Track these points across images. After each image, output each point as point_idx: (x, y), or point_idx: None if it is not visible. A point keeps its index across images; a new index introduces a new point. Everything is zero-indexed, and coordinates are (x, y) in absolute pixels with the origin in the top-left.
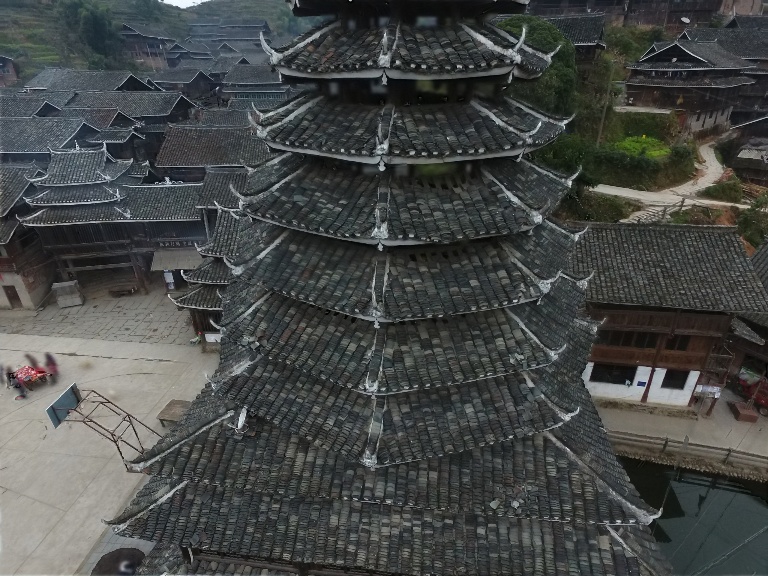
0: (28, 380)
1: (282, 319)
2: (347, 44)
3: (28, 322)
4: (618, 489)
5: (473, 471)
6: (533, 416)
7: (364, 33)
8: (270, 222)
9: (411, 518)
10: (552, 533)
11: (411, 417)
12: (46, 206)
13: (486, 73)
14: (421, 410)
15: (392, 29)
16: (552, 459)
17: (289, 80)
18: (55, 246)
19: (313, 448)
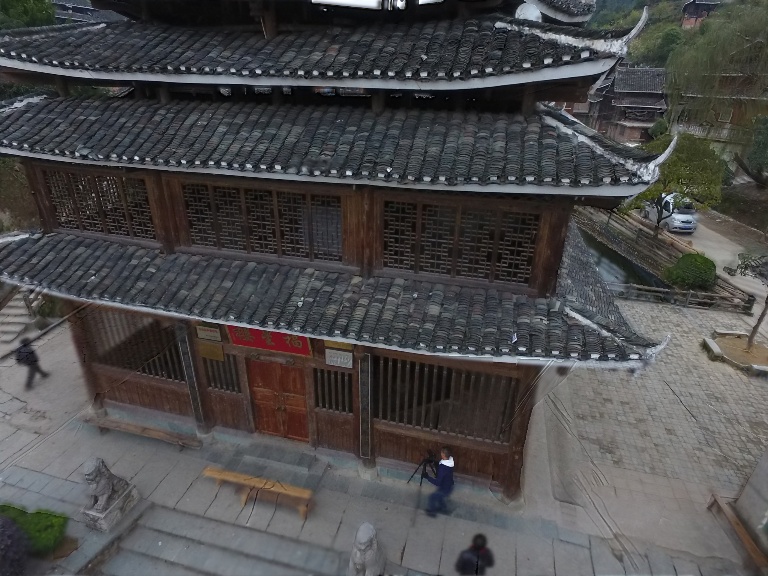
0: None
1: None
2: None
3: None
4: None
5: None
6: None
7: None
8: None
9: None
10: None
11: None
12: None
13: None
14: None
15: None
16: None
17: None
18: None
19: None
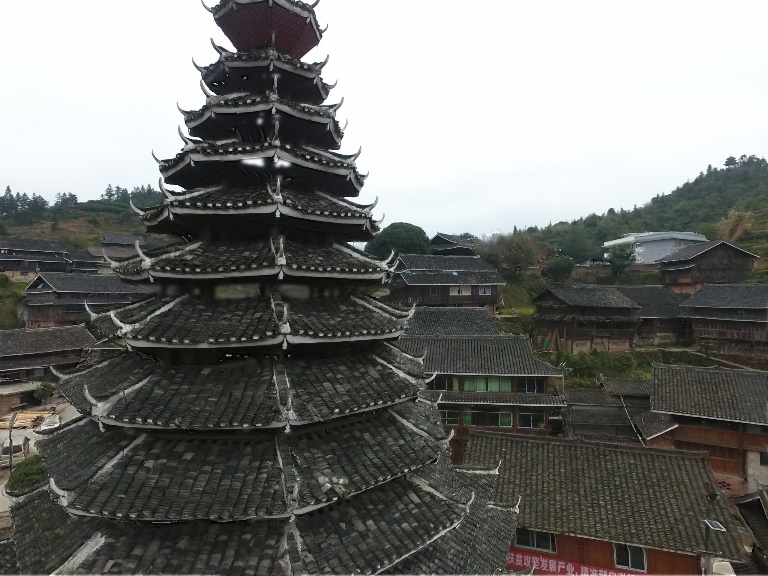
0: None
1: None
2: None
3: None
4: None
5: None
6: None
7: None
8: None
9: None
10: None
11: None
12: None
13: None
14: None
15: None
16: None
17: None
18: None
19: None
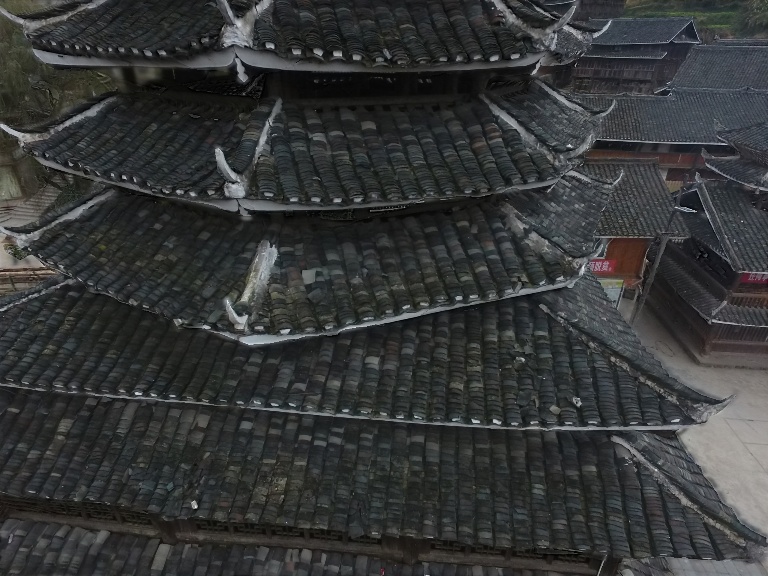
0: None
1: None
2: None
3: None
4: None
5: None
6: None
7: None
8: None
9: None
10: None
11: None
12: None
13: None
14: None
15: None
16: None
17: None
18: None
19: None
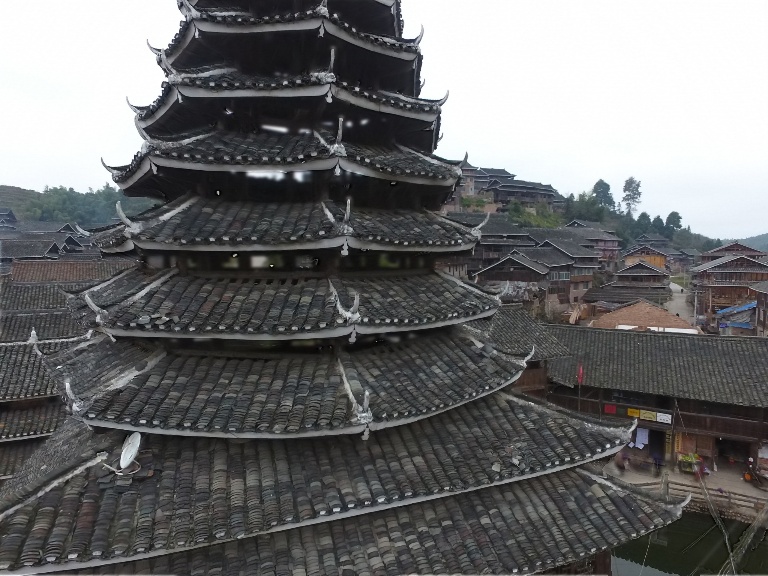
0: None
1: (194, 297)
2: None
3: None
4: (592, 419)
5: (458, 445)
6: (496, 368)
7: None
8: (186, 168)
9: (402, 536)
10: (551, 499)
11: (386, 379)
12: None
13: (398, 55)
14: (392, 373)
15: None
16: (523, 415)
17: (206, 40)
18: None
19: (253, 469)
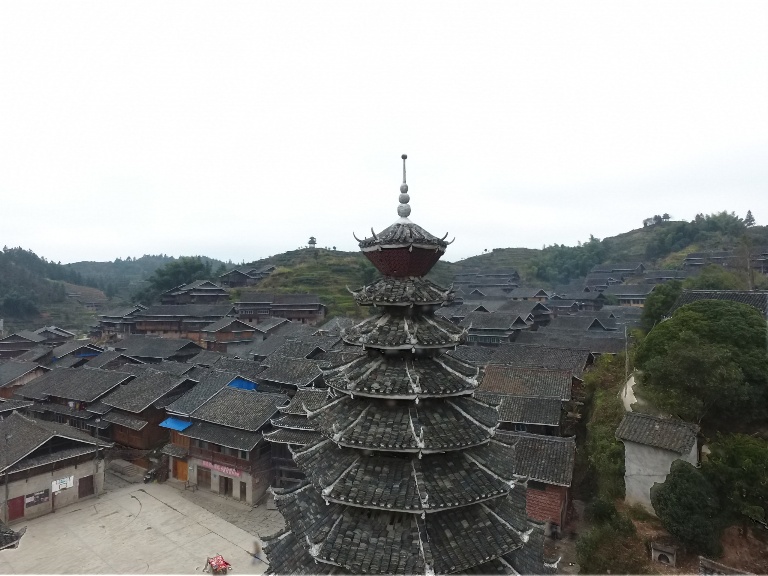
0: (215, 569)
1: None
2: (343, 413)
3: (243, 515)
4: None
5: None
6: None
7: (357, 405)
8: None
9: None
10: None
11: None
12: (281, 427)
13: (402, 450)
14: None
15: (357, 413)
16: None
17: None
18: (278, 458)
19: None
